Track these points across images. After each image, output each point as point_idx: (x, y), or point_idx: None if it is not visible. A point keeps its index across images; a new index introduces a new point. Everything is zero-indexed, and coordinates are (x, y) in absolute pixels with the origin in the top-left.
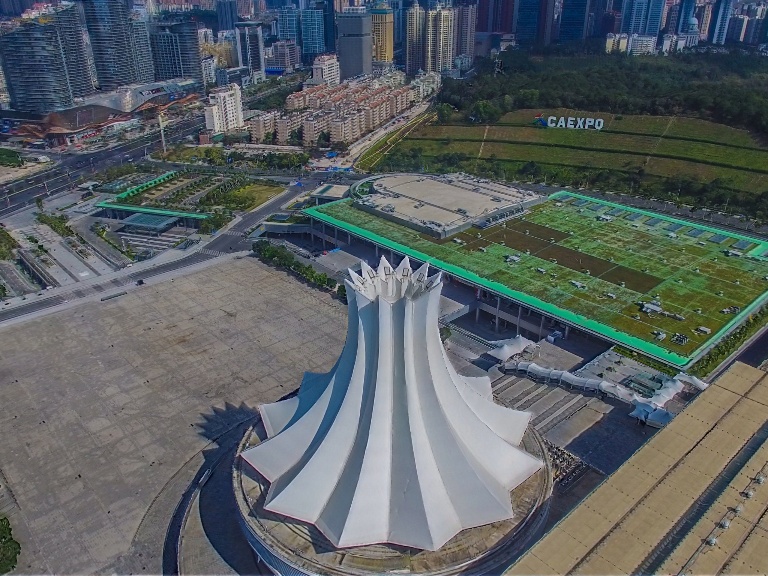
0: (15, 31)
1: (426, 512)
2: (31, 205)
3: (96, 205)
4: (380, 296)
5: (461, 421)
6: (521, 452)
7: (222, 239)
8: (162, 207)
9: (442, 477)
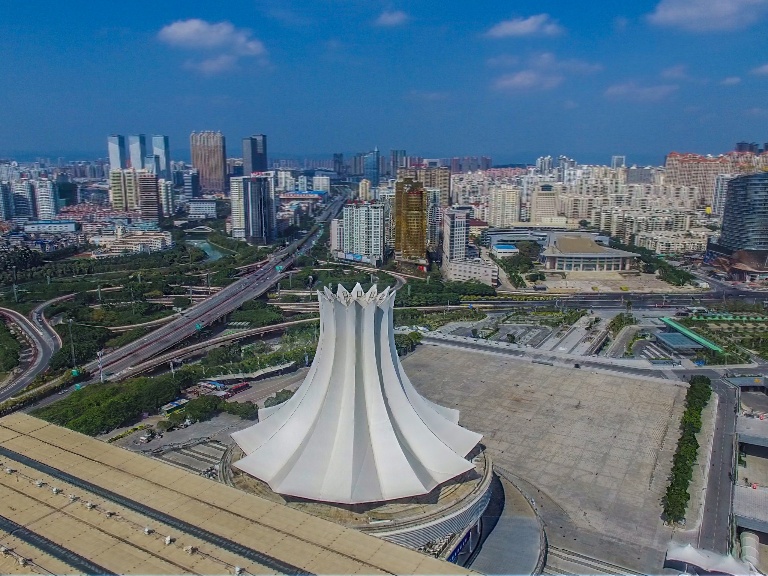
0: (740, 177)
1: (259, 448)
2: (635, 309)
3: (660, 318)
4: (318, 291)
5: (345, 430)
6: (351, 482)
7: (702, 372)
8: (702, 334)
9: (298, 449)
